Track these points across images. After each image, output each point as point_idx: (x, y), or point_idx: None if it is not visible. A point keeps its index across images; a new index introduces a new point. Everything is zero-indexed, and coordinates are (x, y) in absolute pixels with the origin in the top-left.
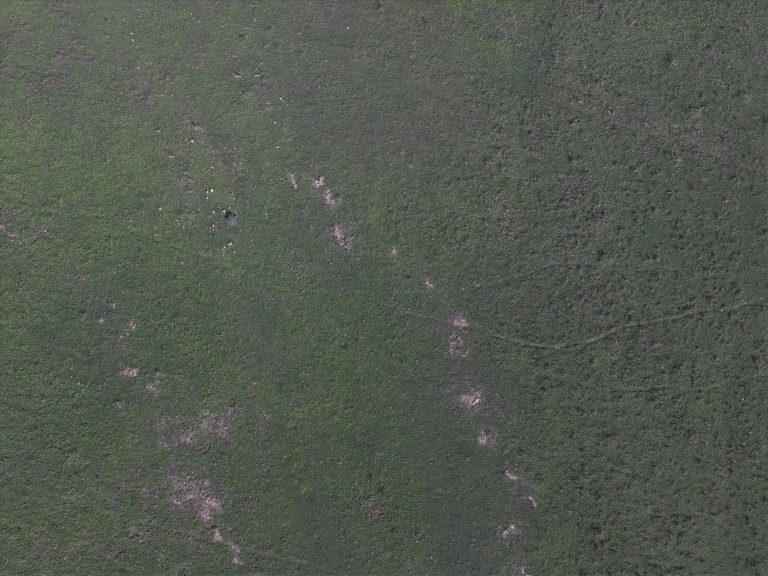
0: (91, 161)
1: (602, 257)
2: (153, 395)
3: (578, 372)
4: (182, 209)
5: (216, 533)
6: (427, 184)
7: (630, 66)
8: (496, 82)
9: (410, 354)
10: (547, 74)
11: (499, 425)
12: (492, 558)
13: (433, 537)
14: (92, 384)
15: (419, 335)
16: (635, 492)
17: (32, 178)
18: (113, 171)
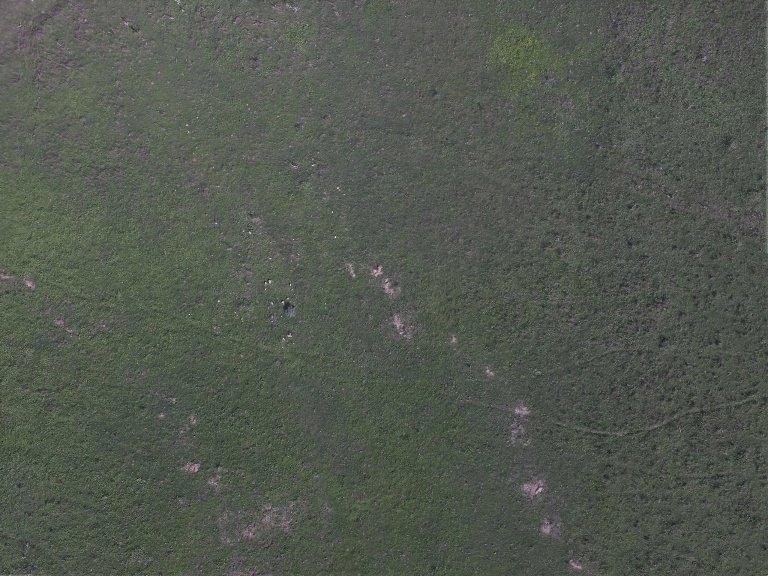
0: (148, 254)
1: (664, 343)
2: (215, 490)
3: (641, 459)
4: (241, 301)
5: None
6: (486, 271)
7: (688, 149)
8: (553, 167)
9: (472, 443)
10: (605, 158)
11: (562, 514)
12: None
13: None
14: (153, 480)
15: (480, 424)
16: None
17: (90, 273)
18: (171, 264)
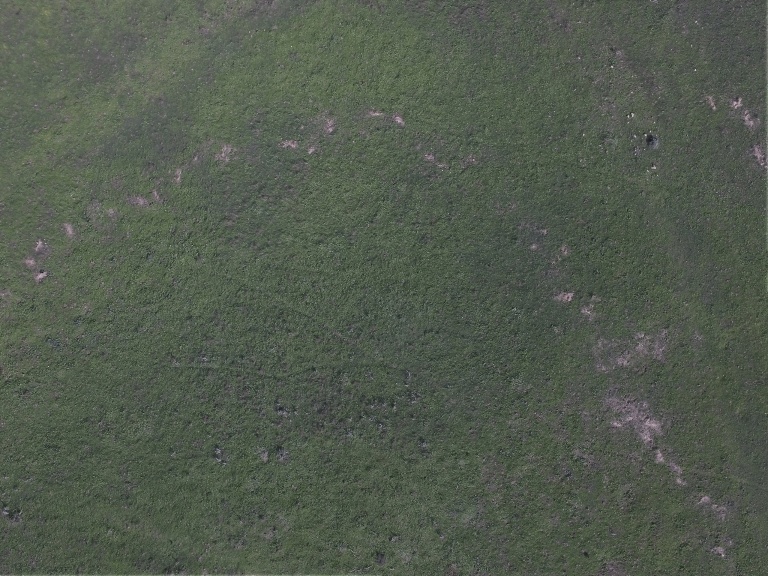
0: (513, 90)
1: None
2: (588, 319)
3: None
4: (605, 134)
5: (658, 454)
6: None
7: None
8: None
9: None
10: None
11: None
12: None
13: None
14: (528, 310)
15: None
16: None
17: (457, 109)
18: (534, 99)
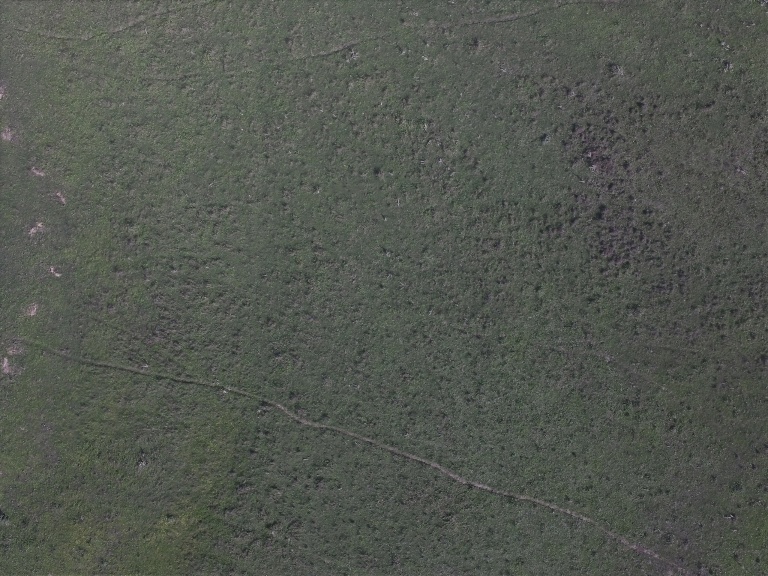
0: None
1: None
2: None
3: (106, 62)
4: None
5: None
6: None
7: None
8: None
9: None
10: None
11: (24, 121)
12: (19, 258)
13: None
14: None
15: None
16: (168, 183)
17: None
18: None
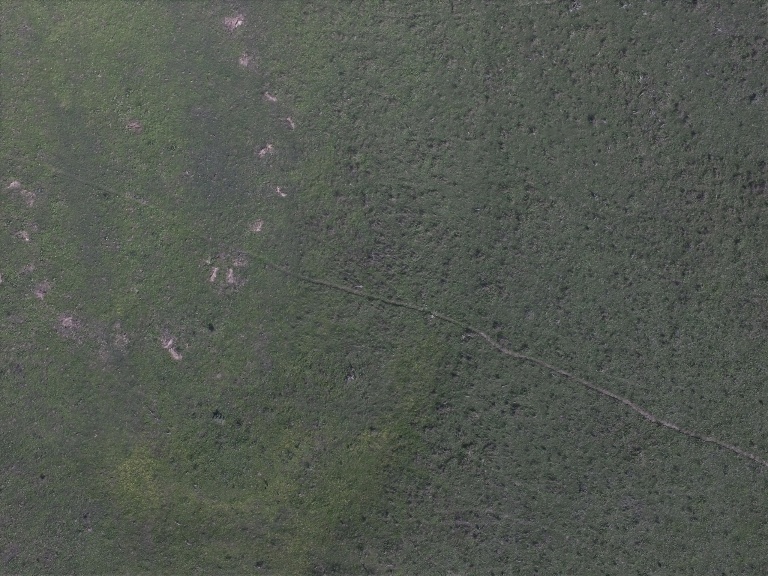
0: None
1: None
2: None
3: None
4: None
5: None
6: None
7: None
8: None
9: None
10: None
11: (261, 48)
12: (248, 176)
13: (190, 153)
14: None
15: None
16: (392, 115)
17: None
18: None
